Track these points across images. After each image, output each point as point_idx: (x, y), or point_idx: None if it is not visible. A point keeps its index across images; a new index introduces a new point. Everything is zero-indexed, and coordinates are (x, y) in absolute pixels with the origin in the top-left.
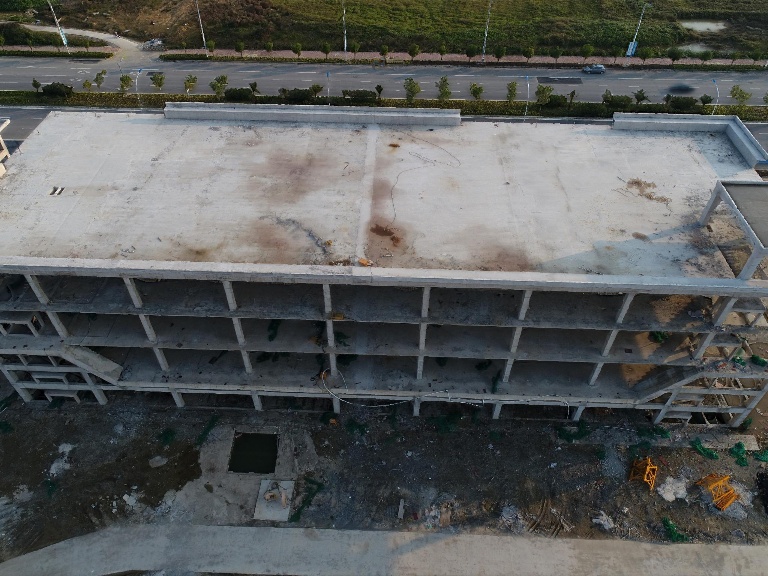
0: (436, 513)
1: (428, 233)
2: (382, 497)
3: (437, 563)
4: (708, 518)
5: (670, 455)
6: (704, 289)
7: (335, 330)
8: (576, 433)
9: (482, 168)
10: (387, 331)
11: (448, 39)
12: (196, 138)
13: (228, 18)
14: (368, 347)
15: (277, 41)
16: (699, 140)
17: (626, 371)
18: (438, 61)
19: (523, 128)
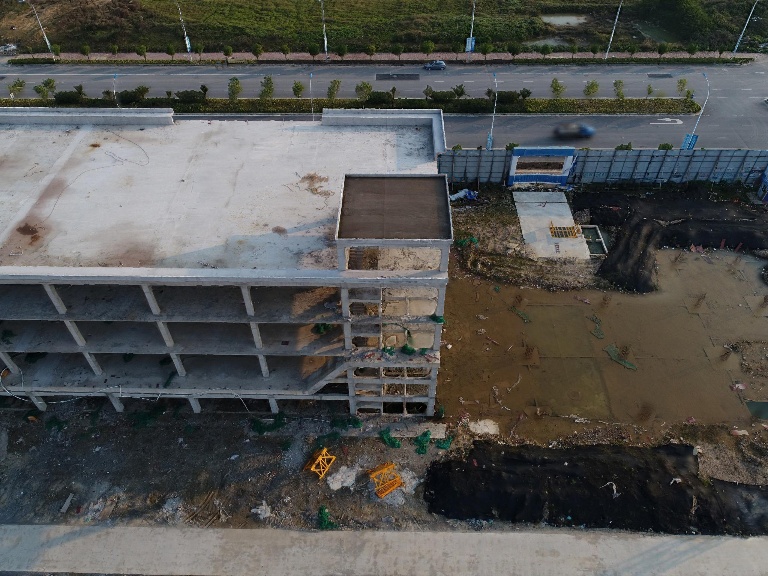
0: (100, 506)
1: (71, 231)
2: (54, 492)
3: (81, 555)
4: (366, 505)
5: (354, 445)
6: (294, 280)
7: (5, 329)
8: (270, 425)
9: (167, 166)
10: (56, 328)
11: (302, 38)
12: None
13: (89, 21)
14: (30, 345)
15: (133, 43)
16: (401, 134)
17: (306, 363)
18: (284, 60)
19: (234, 126)
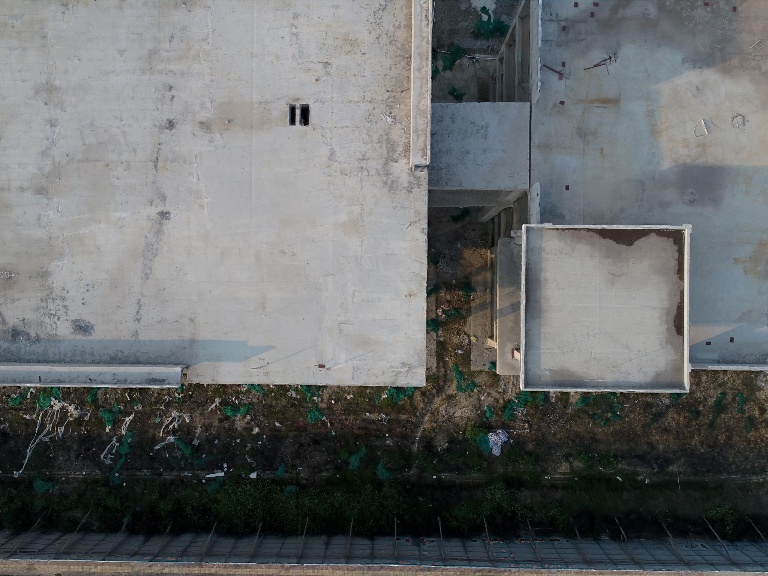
0: None
1: None
2: None
3: None
4: None
5: None
6: None
7: None
8: None
9: None
10: None
11: None
12: (109, 292)
13: None
14: None
15: None
16: None
17: None
18: None
19: None
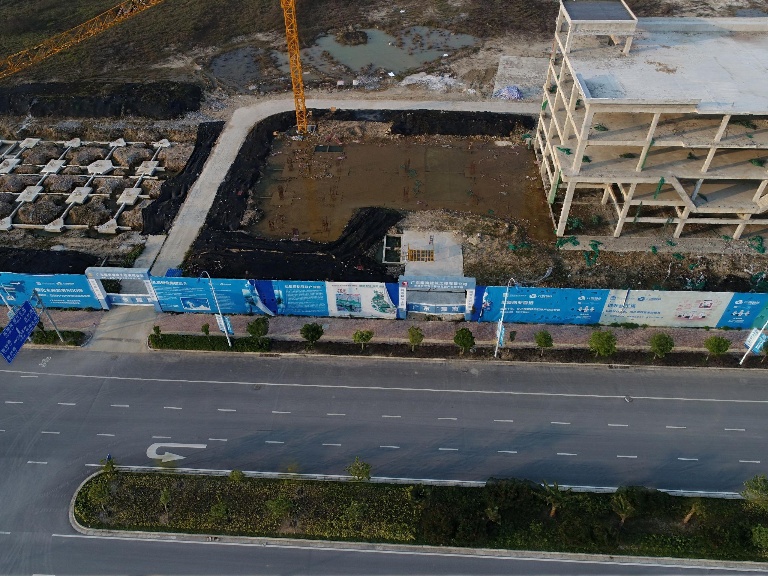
0: None
1: None
2: None
3: None
4: None
5: None
6: None
7: None
8: None
9: None
10: None
11: None
12: None
13: None
14: None
15: None
16: None
17: None
18: None
19: None
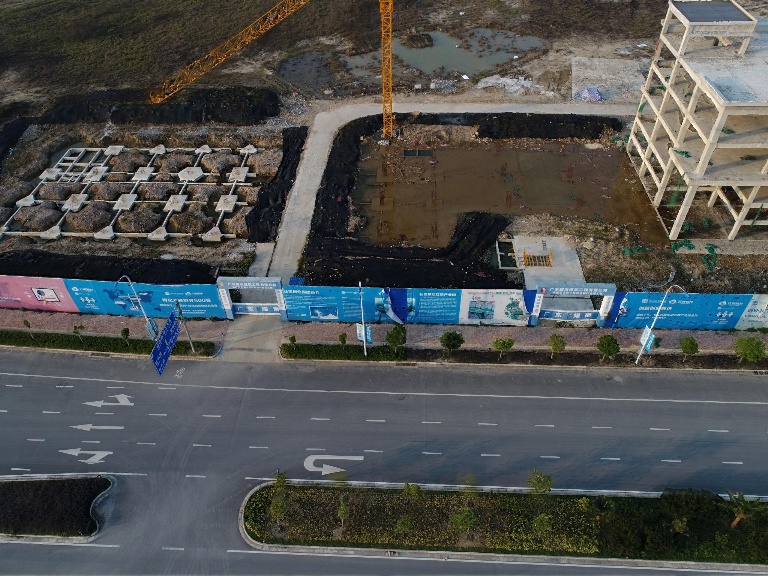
0: None
1: None
2: None
3: None
4: None
5: None
6: None
7: None
8: None
9: None
10: None
11: None
12: None
13: None
14: None
15: None
16: None
17: None
18: None
19: None
